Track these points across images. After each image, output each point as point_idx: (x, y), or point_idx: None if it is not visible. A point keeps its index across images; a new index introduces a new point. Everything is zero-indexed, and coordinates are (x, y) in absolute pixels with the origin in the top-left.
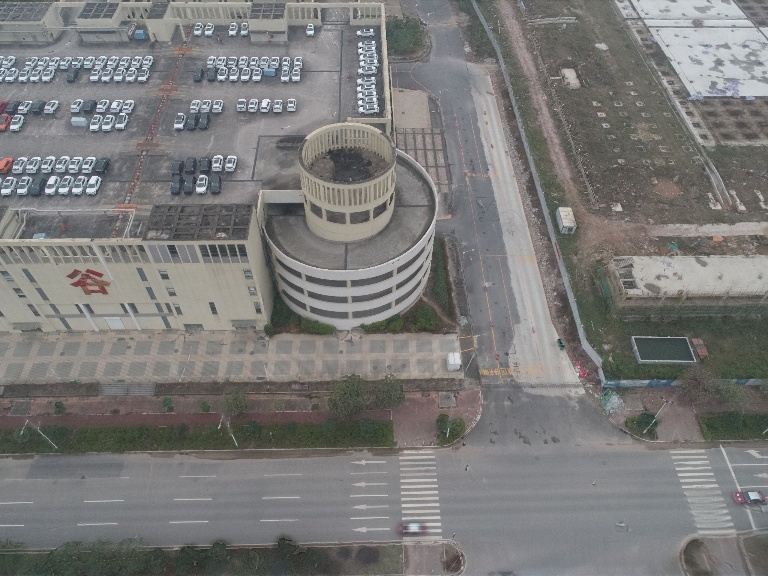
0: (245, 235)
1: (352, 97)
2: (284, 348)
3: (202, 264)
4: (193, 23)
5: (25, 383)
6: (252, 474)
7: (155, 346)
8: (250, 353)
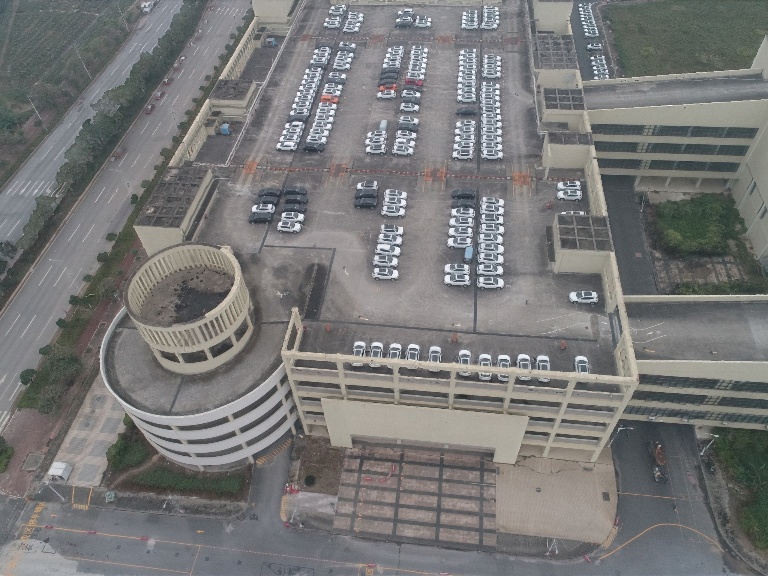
0: (140, 224)
1: (402, 341)
2: None
3: None
4: None
5: None
6: (58, 309)
7: None
8: None
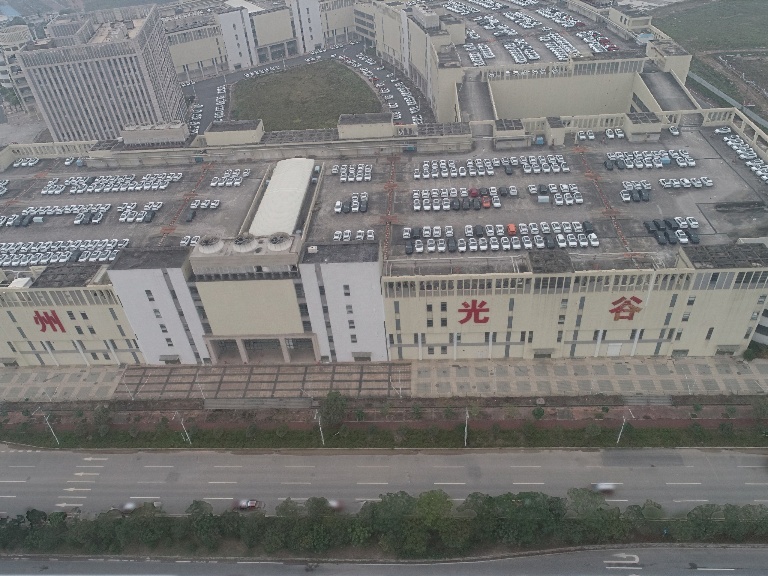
0: None
1: (750, 175)
2: (765, 370)
3: (730, 290)
4: (573, 131)
5: (559, 395)
6: None
7: (651, 368)
8: (737, 373)
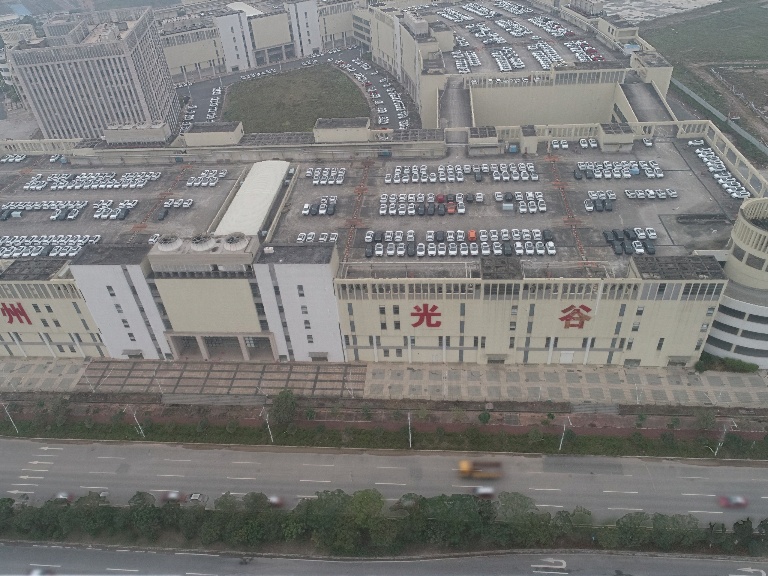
0: (724, 276)
1: (716, 187)
2: (715, 382)
3: (678, 301)
4: (547, 140)
5: (508, 401)
6: (741, 478)
7: (602, 377)
8: (688, 385)
